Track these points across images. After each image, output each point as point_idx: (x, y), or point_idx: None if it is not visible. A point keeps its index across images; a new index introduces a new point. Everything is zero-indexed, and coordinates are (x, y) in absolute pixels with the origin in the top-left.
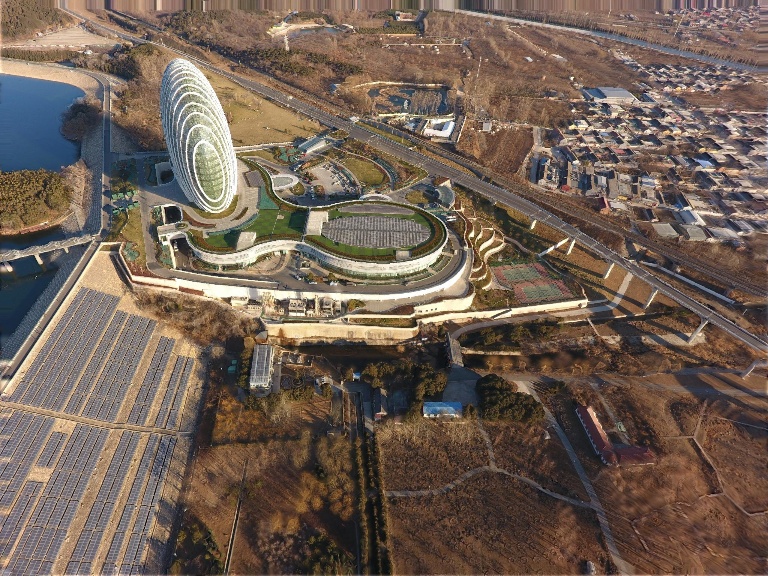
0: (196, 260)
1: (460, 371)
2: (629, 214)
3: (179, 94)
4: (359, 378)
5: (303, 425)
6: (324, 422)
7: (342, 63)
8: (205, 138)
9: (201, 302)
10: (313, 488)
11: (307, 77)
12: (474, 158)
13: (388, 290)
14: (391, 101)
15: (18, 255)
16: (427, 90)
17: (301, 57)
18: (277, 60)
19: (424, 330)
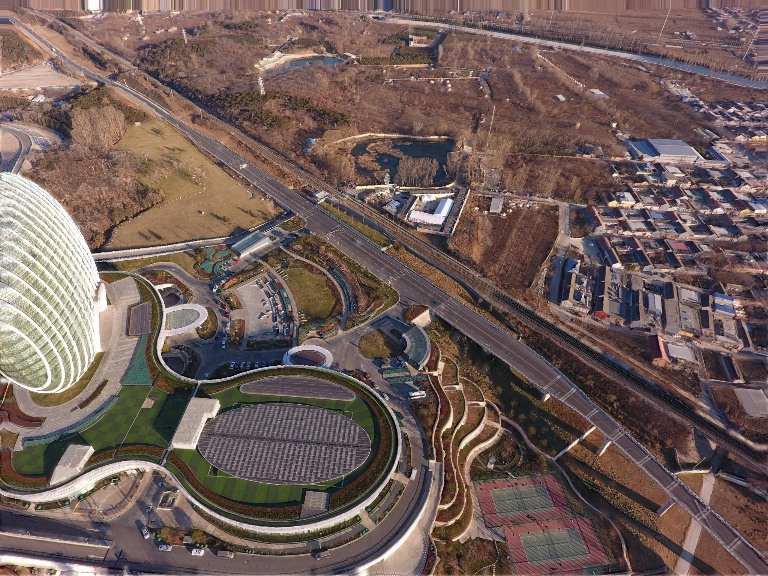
0: None
1: None
2: (697, 369)
3: None
4: None
5: None
6: None
7: (325, 110)
8: None
9: None
10: None
11: (279, 130)
12: (472, 262)
13: (285, 570)
14: (378, 162)
15: None
16: (428, 143)
17: (278, 102)
18: (248, 107)
19: None
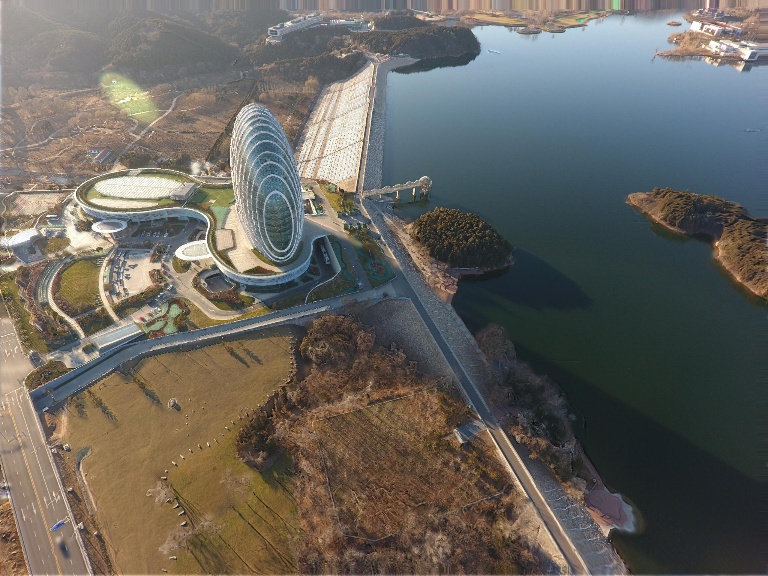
0: None
1: None
2: None
3: None
4: None
5: None
6: None
7: None
8: None
9: None
10: None
11: None
12: None
13: None
14: None
15: None
16: None
17: None
18: None
19: None
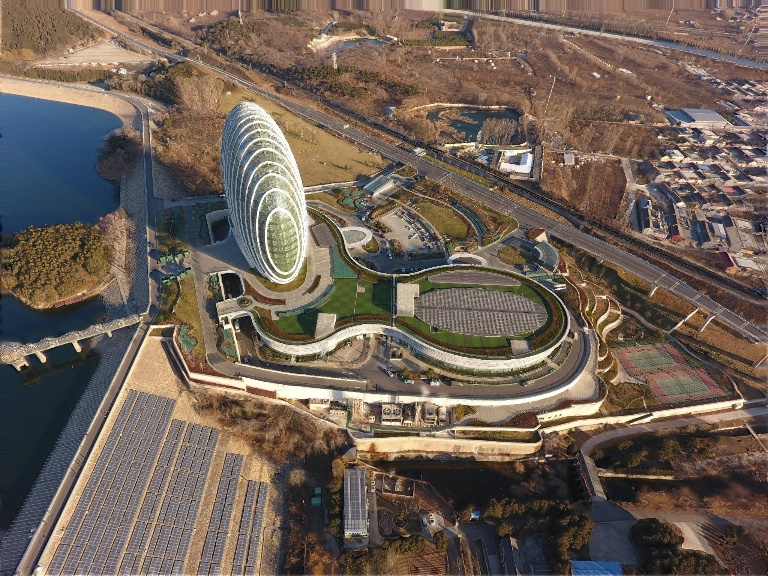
0: (263, 346)
1: (603, 506)
2: (762, 275)
3: (251, 151)
4: (478, 517)
5: None
6: None
7: (396, 82)
8: (281, 204)
9: (274, 407)
10: None
11: (359, 99)
12: (564, 201)
13: (503, 393)
14: (454, 127)
15: (53, 344)
16: (490, 112)
17: (350, 76)
18: (325, 80)
19: (549, 445)
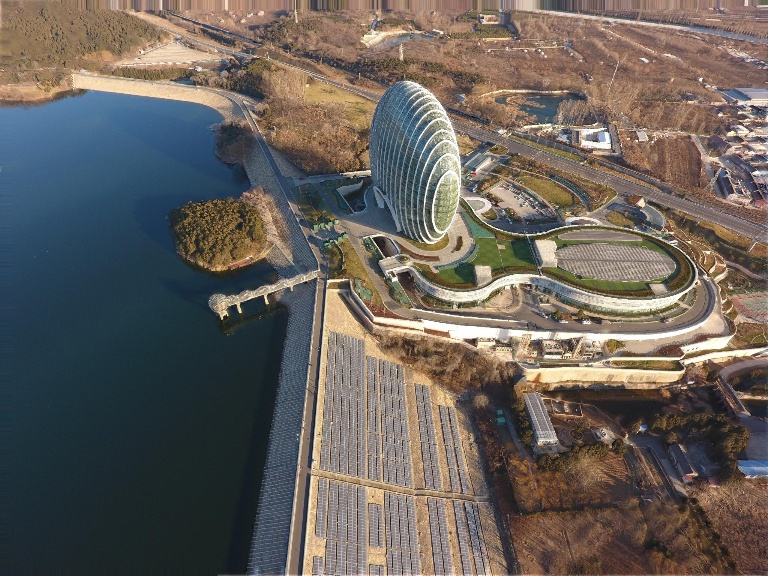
0: (424, 296)
1: (749, 421)
2: None
3: (426, 121)
4: (644, 431)
5: (606, 488)
6: (628, 484)
7: (461, 72)
8: (452, 167)
9: (450, 345)
10: (675, 572)
11: (430, 88)
12: (650, 172)
13: (648, 329)
14: (524, 111)
15: (251, 296)
16: (552, 97)
17: (416, 67)
18: (394, 71)
19: (691, 373)
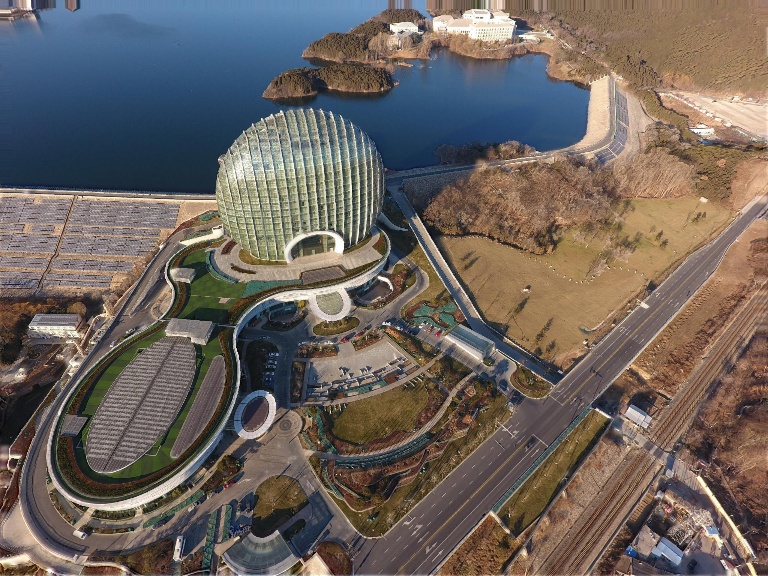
0: None
1: None
2: None
3: None
4: None
5: None
6: None
7: None
8: (221, 175)
9: None
10: None
11: None
12: None
13: None
14: None
15: None
16: None
17: None
18: None
19: None
